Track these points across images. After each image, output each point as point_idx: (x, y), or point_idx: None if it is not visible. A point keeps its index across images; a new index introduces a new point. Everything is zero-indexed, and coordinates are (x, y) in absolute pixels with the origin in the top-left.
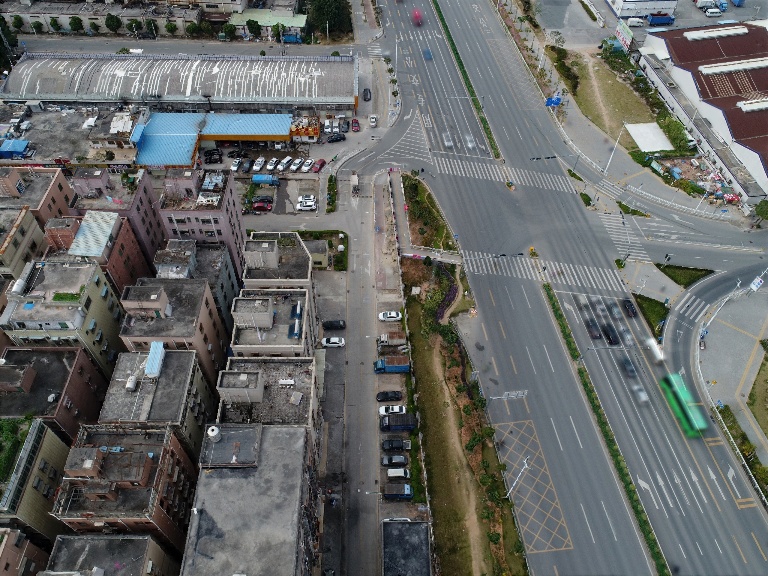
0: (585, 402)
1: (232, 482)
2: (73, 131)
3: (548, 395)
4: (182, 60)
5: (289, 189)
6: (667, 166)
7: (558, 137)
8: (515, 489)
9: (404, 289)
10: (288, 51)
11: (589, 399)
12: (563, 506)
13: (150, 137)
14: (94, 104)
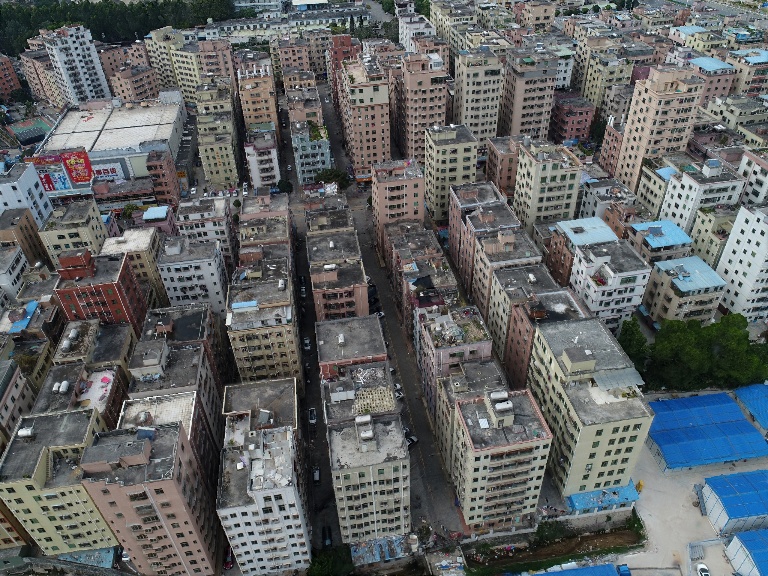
0: None
1: None
2: None
3: None
4: None
5: None
6: None
7: None
8: None
9: None
10: None
11: None
12: None
13: None
14: None
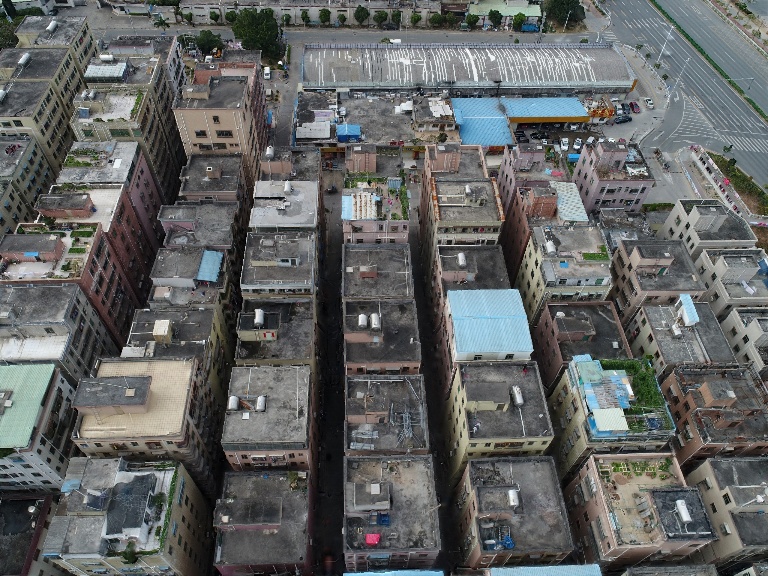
0: None
1: None
2: (388, 116)
3: None
4: (451, 49)
5: None
6: None
7: None
8: None
9: None
10: (529, 39)
11: None
12: None
13: None
14: (388, 91)
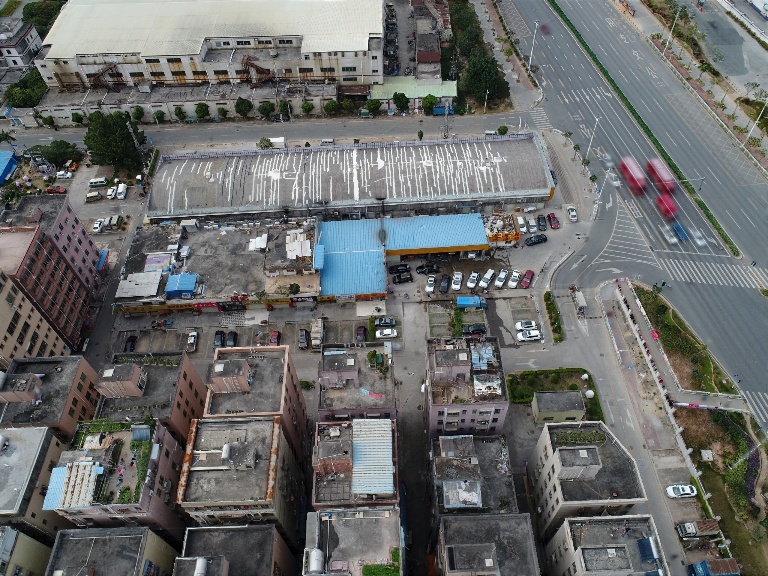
0: None
1: None
2: (240, 255)
3: None
4: (336, 151)
5: (500, 312)
6: None
7: None
8: None
9: (692, 454)
10: None
11: None
12: None
13: (329, 257)
14: (251, 215)
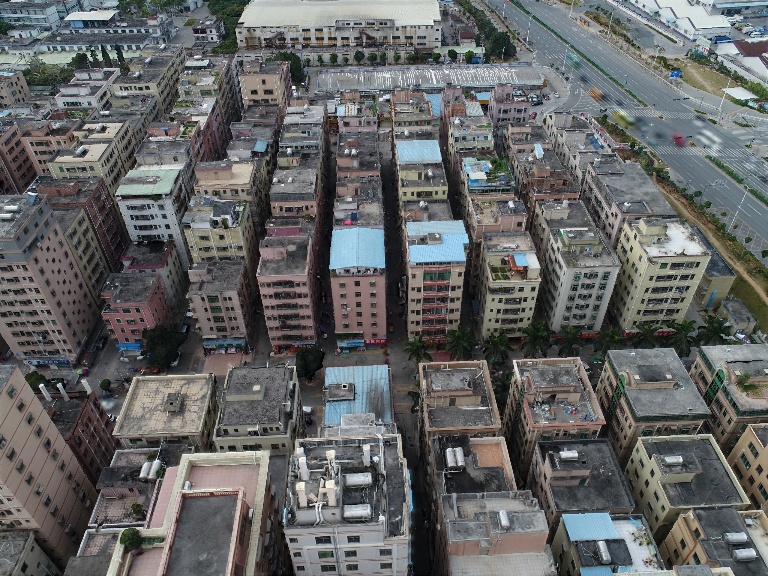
0: (755, 199)
1: (615, 178)
2: None
3: (731, 197)
4: None
5: None
6: (759, 104)
7: (680, 97)
8: (731, 231)
9: None
10: None
11: (757, 197)
12: (761, 235)
13: None
14: None
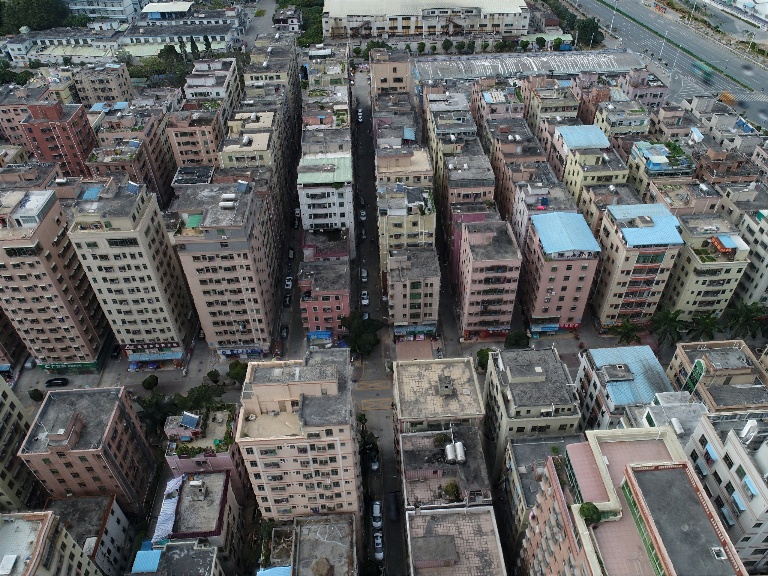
0: None
1: None
2: None
3: None
4: (514, 57)
5: None
6: None
7: None
8: None
9: None
10: None
11: None
12: None
13: None
14: None
